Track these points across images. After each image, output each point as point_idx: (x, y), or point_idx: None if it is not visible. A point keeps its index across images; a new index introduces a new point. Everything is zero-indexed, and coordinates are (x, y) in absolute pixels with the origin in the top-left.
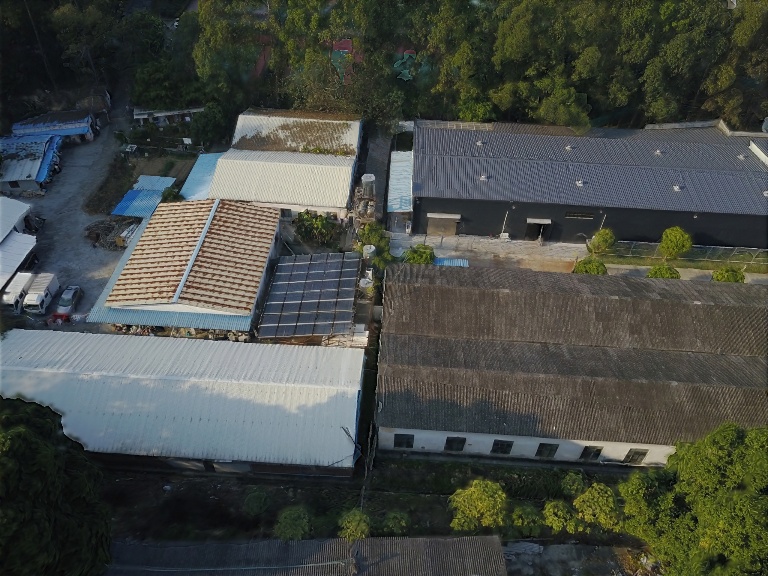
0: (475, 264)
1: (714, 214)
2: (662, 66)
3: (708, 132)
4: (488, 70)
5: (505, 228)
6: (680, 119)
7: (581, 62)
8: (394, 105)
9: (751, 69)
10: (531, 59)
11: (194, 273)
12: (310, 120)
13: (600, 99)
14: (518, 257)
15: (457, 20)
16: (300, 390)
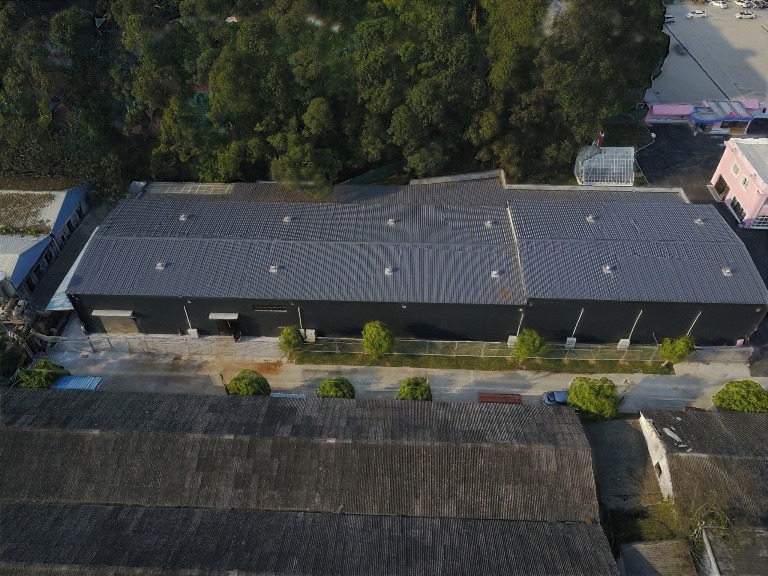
0: (145, 371)
1: (422, 304)
2: (407, 116)
3: (484, 185)
4: (205, 128)
5: (191, 323)
6: (476, 165)
7: (307, 116)
8: (107, 171)
9: (516, 115)
10: (263, 112)
11: None
12: (9, 192)
13: (357, 152)
14: (202, 359)
15: (162, 72)
16: None
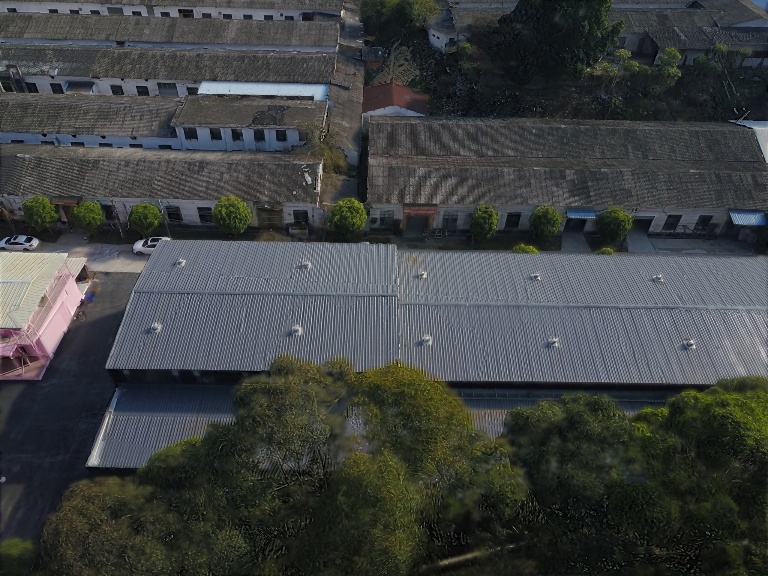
0: None
1: None
2: None
3: None
4: None
5: None
6: None
7: None
8: None
9: None
10: None
11: None
12: None
13: None
14: None
15: None
16: None
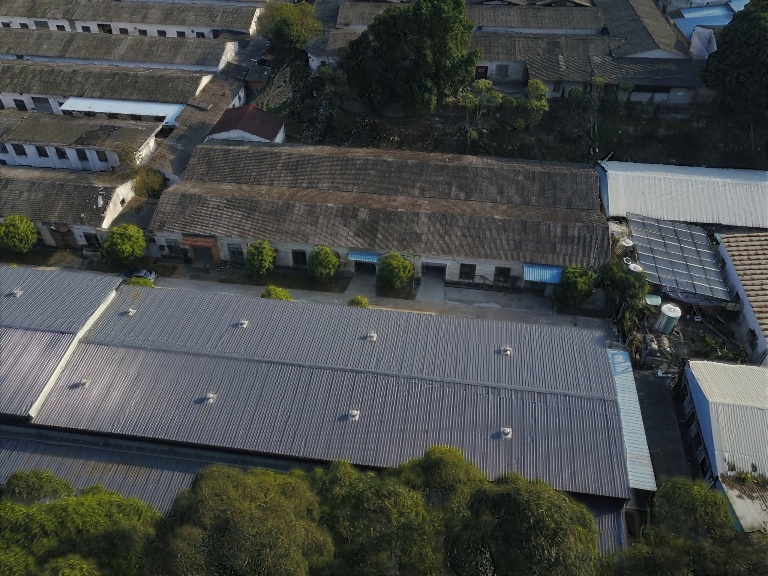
0: None
1: None
2: None
3: None
4: None
5: None
6: None
7: None
8: None
9: None
10: None
11: None
12: None
13: None
14: None
15: None
16: (648, 174)
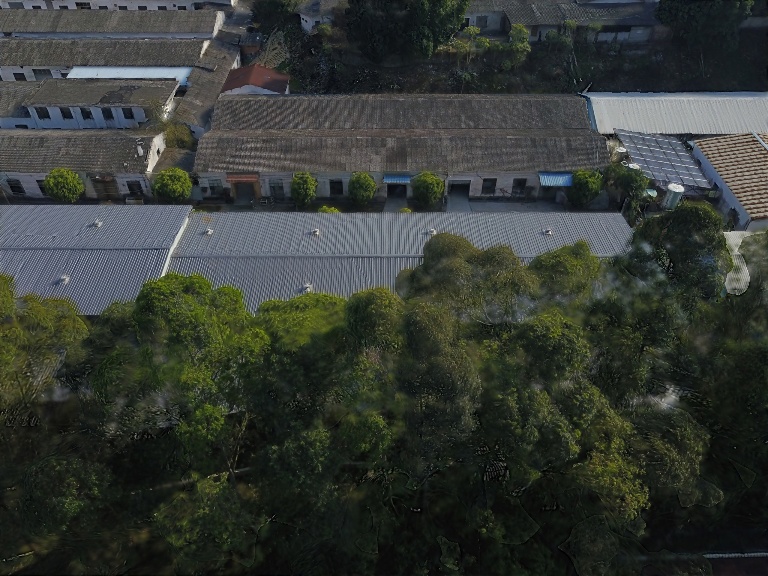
0: None
1: None
2: None
3: None
4: None
5: None
6: None
7: None
8: None
9: None
10: None
11: (762, 149)
12: None
13: None
14: None
15: None
16: None
